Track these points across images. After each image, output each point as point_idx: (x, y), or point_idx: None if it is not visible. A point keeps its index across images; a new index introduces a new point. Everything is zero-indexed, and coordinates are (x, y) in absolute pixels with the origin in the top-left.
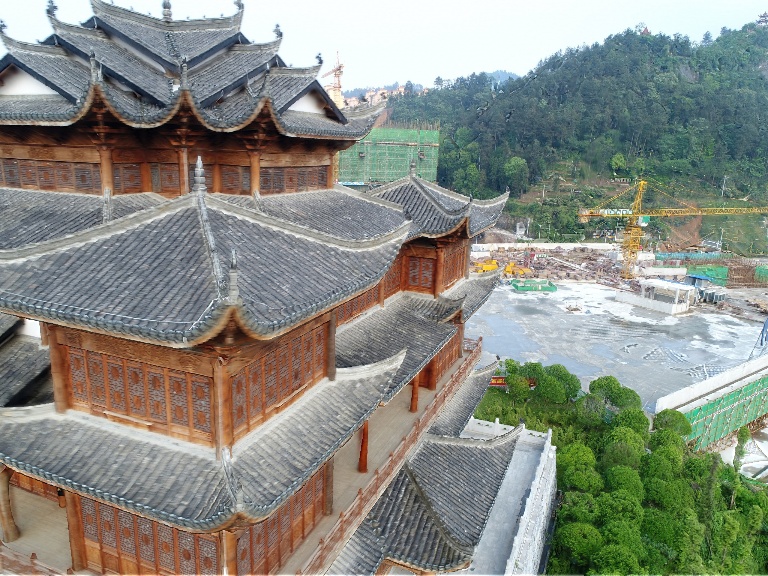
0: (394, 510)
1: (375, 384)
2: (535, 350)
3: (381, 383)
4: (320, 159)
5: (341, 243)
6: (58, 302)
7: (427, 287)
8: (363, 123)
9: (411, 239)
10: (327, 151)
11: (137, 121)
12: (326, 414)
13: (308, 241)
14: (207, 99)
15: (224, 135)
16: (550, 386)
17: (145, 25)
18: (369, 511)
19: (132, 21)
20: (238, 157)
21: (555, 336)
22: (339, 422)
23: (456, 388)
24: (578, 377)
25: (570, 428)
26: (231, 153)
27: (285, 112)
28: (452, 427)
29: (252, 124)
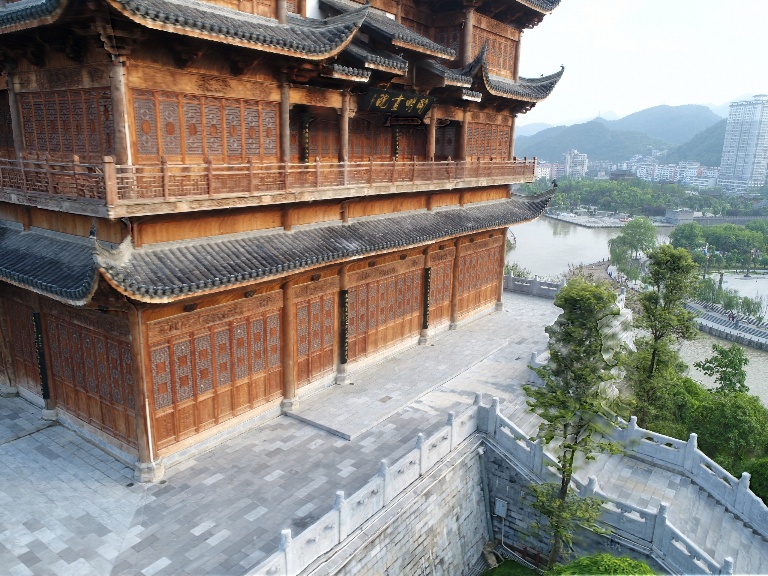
0: None
1: None
2: None
3: None
4: None
5: None
6: None
7: None
8: None
9: None
10: None
11: None
12: None
13: None
14: None
15: None
16: None
17: None
18: None
19: None
20: None
21: None
22: None
23: None
24: None
25: None
26: None
27: None
28: None
29: None
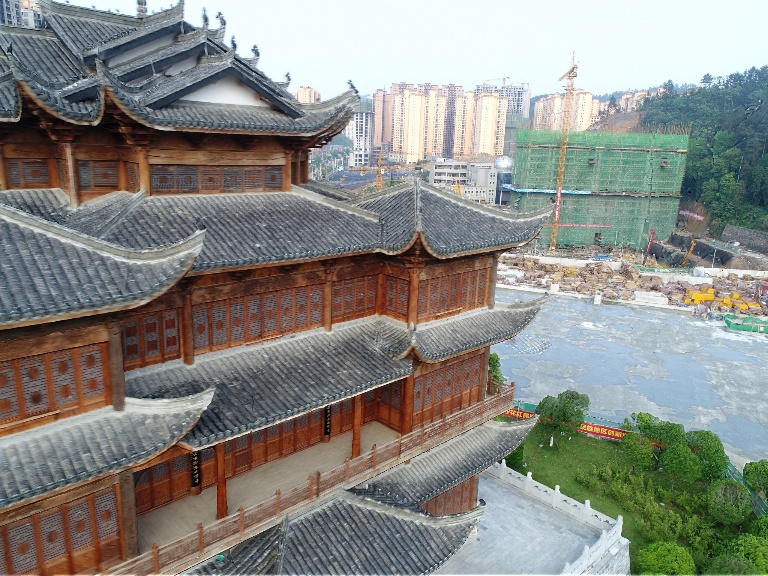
0: (243, 575)
1: (169, 424)
2: (713, 406)
3: (178, 424)
4: (265, 158)
5: (117, 252)
6: None
7: (402, 314)
8: (322, 117)
9: (350, 254)
10: (276, 149)
11: (4, 115)
12: (69, 449)
13: (72, 247)
14: (83, 91)
15: (96, 129)
16: (678, 458)
17: (110, 23)
18: (182, 570)
19: (93, 19)
20: (133, 153)
21: (753, 393)
22: (77, 462)
23: (435, 441)
24: (759, 452)
25: (693, 518)
26: (128, 149)
27: (191, 104)
28: (422, 488)
29: (106, 116)
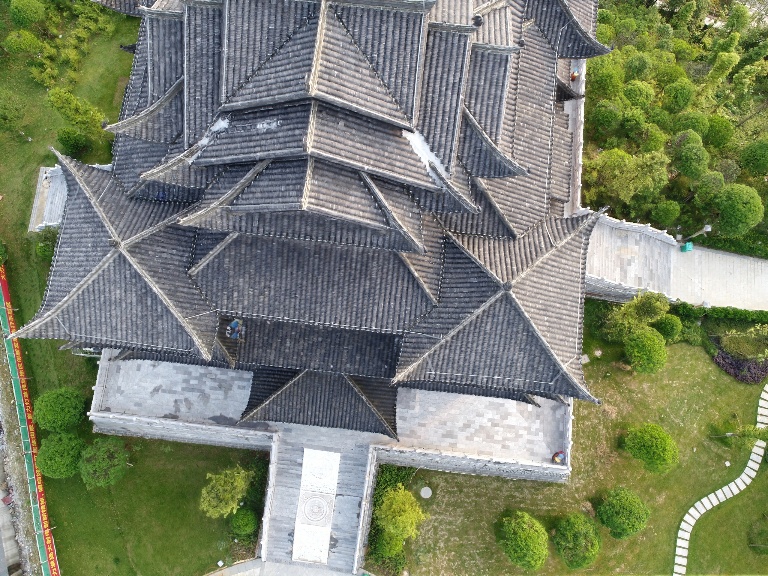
0: None
1: None
2: None
3: None
4: None
5: None
6: (592, 3)
7: None
8: None
9: None
10: None
11: None
12: None
13: None
14: None
15: None
16: (30, 7)
17: None
18: None
19: None
20: None
21: None
22: None
23: None
24: None
25: (79, 7)
26: None
27: None
28: None
29: None
